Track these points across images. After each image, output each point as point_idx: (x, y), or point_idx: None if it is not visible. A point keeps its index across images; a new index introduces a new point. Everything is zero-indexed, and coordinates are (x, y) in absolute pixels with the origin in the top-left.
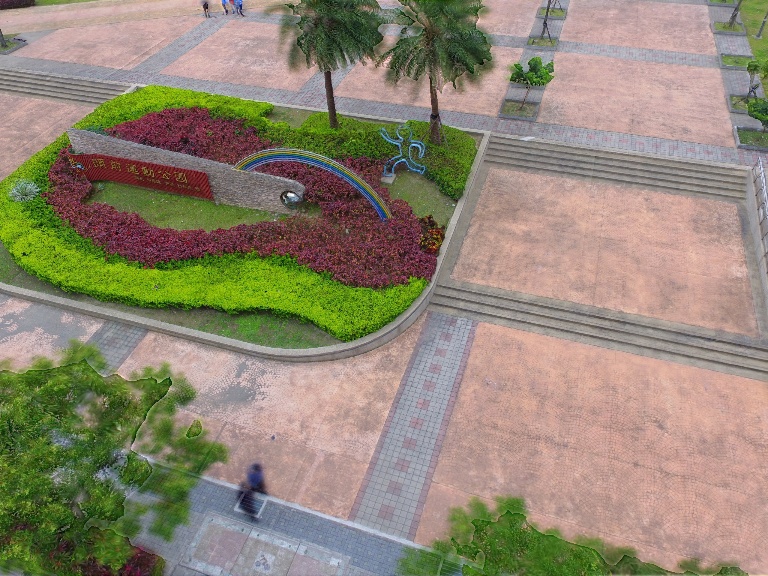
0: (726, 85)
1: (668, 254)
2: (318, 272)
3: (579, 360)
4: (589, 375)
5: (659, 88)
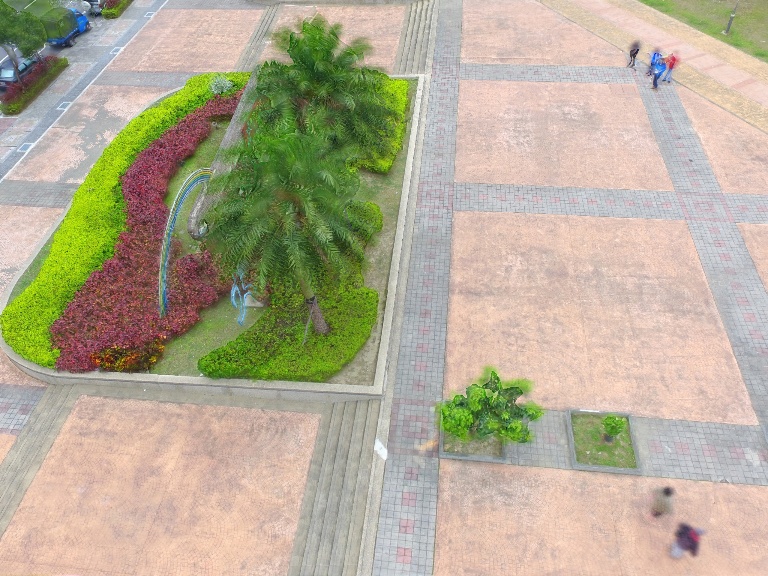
0: None
1: None
2: None
3: None
4: None
5: None
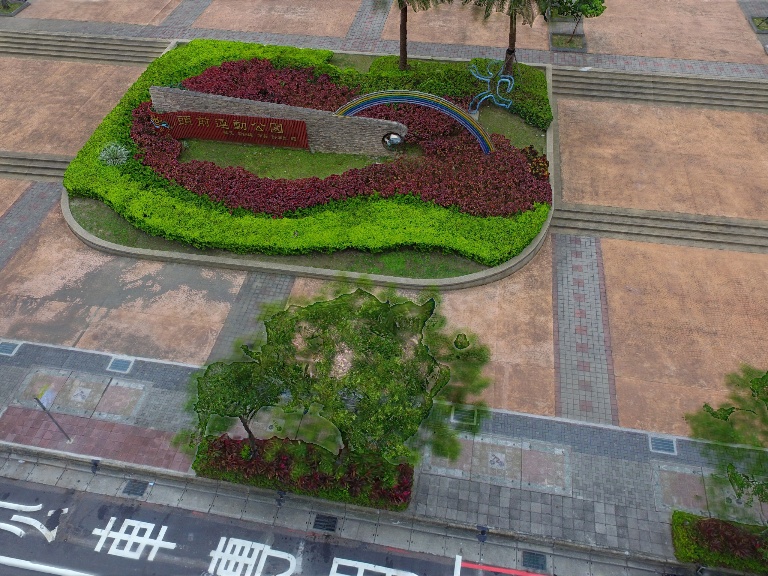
0: (743, 8)
1: (745, 164)
2: (445, 206)
3: (700, 262)
4: (713, 273)
5: (686, 15)
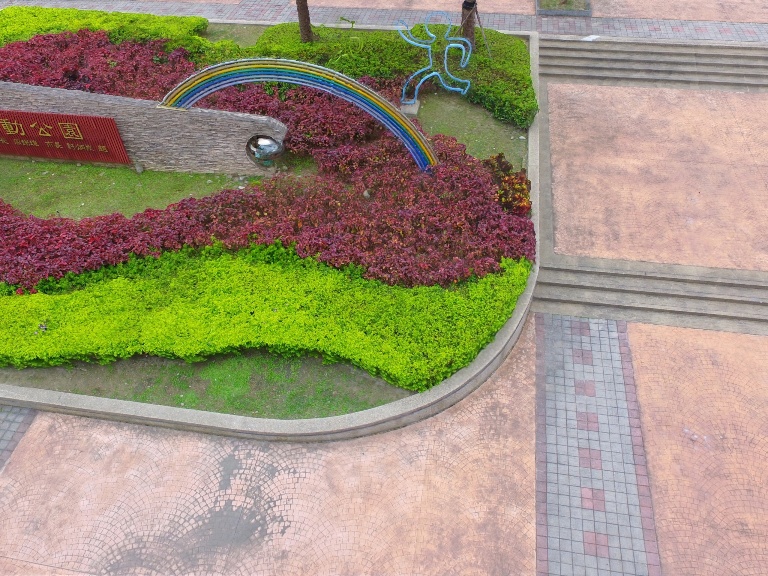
0: None
1: None
2: (337, 267)
3: None
4: None
5: None
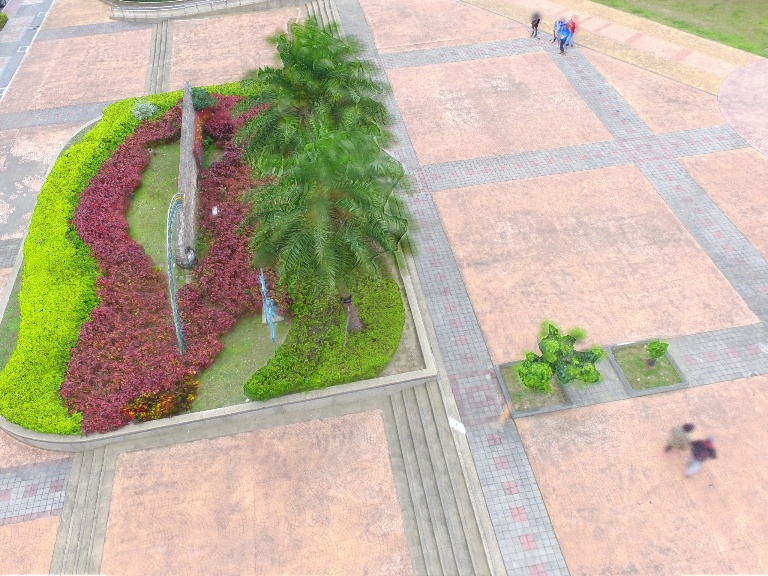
0: None
1: None
2: None
3: None
4: None
5: None
